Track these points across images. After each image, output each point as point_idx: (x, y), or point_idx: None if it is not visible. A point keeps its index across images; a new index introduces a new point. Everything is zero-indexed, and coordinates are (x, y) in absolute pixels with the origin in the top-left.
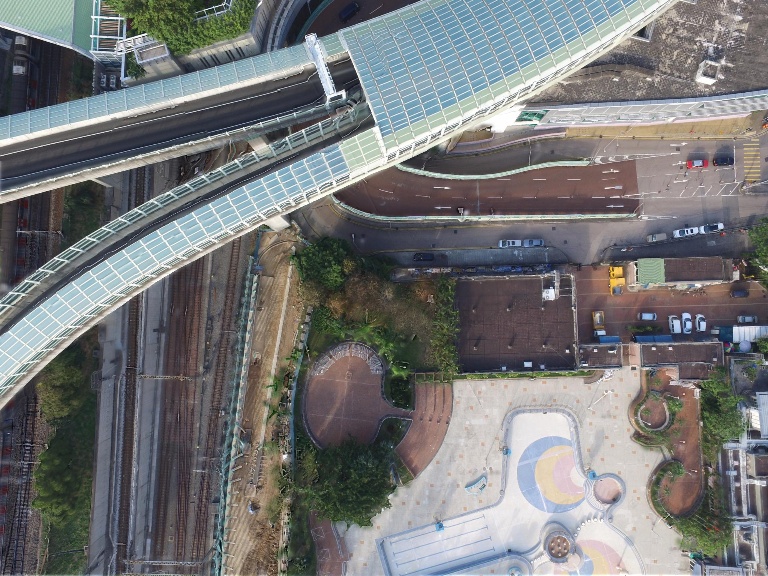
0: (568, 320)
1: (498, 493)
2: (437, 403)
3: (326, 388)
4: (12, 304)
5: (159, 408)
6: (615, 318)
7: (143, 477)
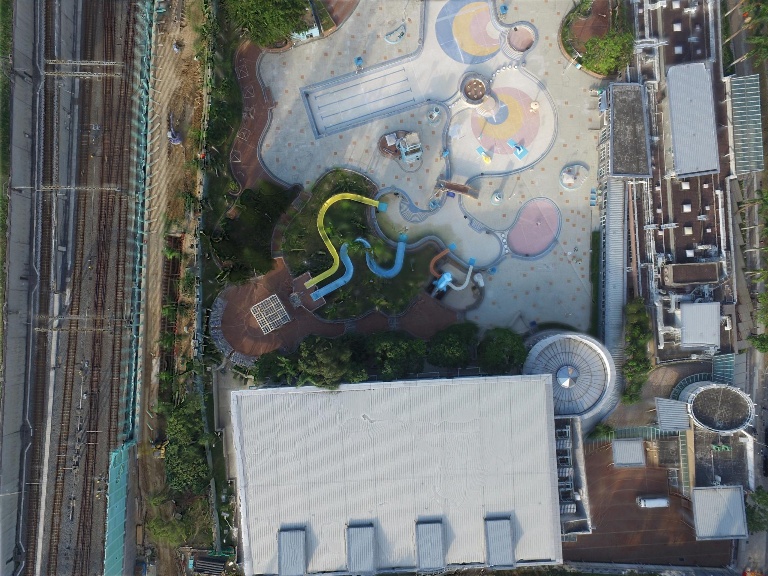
0: None
1: (416, 42)
2: None
3: None
4: None
5: None
6: None
7: (67, 10)
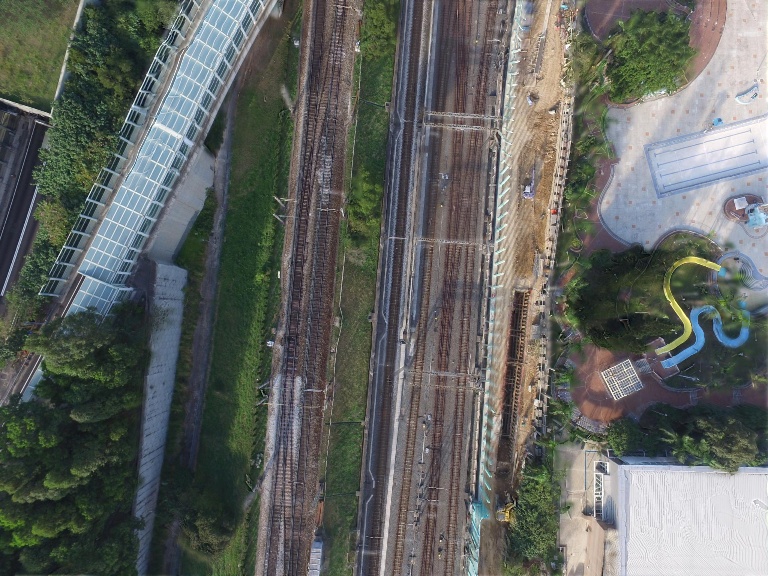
0: None
1: None
2: (712, 11)
3: None
4: None
5: (438, 5)
6: None
7: None
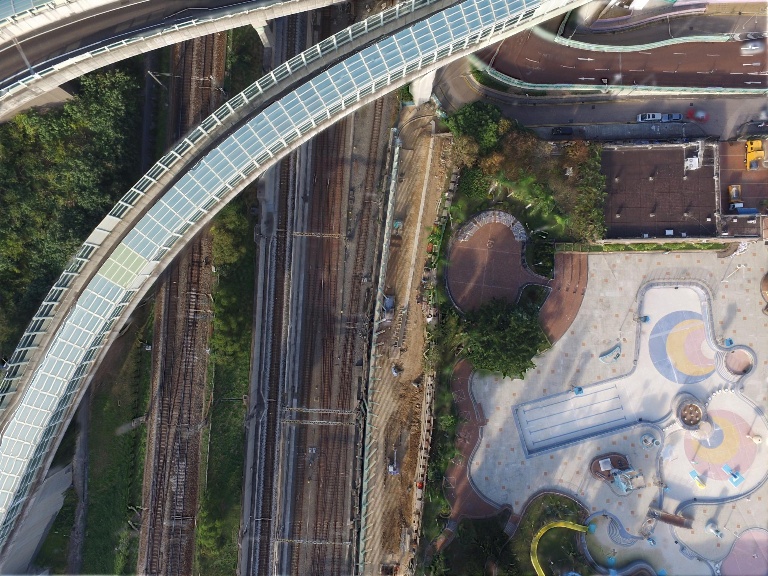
0: (709, 190)
1: (631, 363)
2: (573, 274)
3: (467, 256)
4: (208, 132)
5: (303, 274)
6: (750, 194)
7: (292, 337)
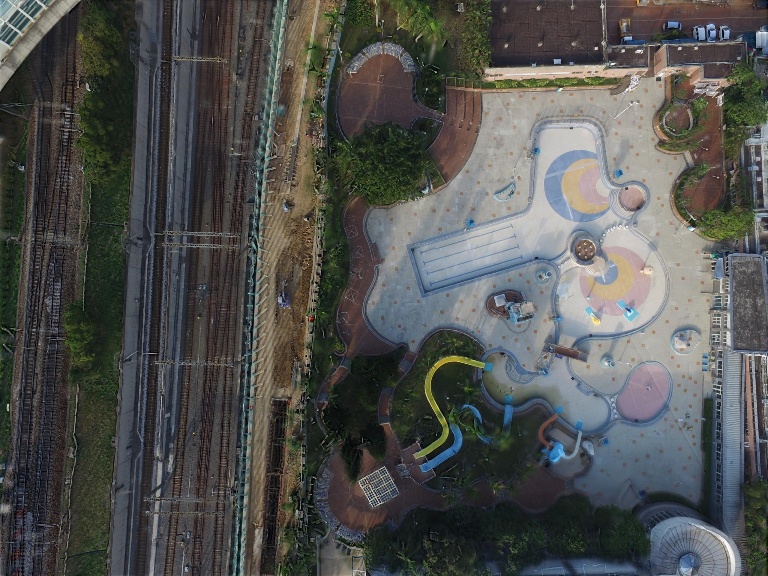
0: (597, 19)
1: (526, 200)
2: (467, 111)
3: (358, 91)
4: None
5: (193, 112)
6: (641, 30)
7: (179, 170)
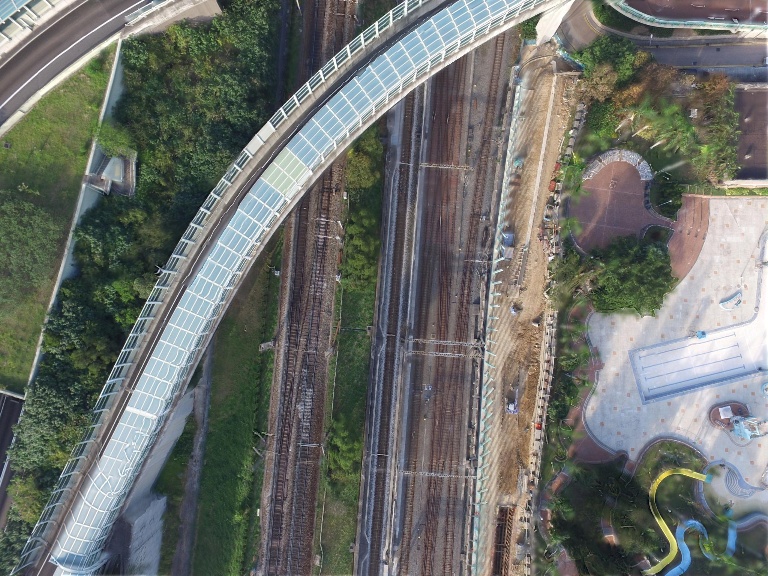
0: None
1: (752, 310)
2: (695, 218)
3: (589, 196)
4: (365, 44)
5: (421, 211)
6: None
7: None
